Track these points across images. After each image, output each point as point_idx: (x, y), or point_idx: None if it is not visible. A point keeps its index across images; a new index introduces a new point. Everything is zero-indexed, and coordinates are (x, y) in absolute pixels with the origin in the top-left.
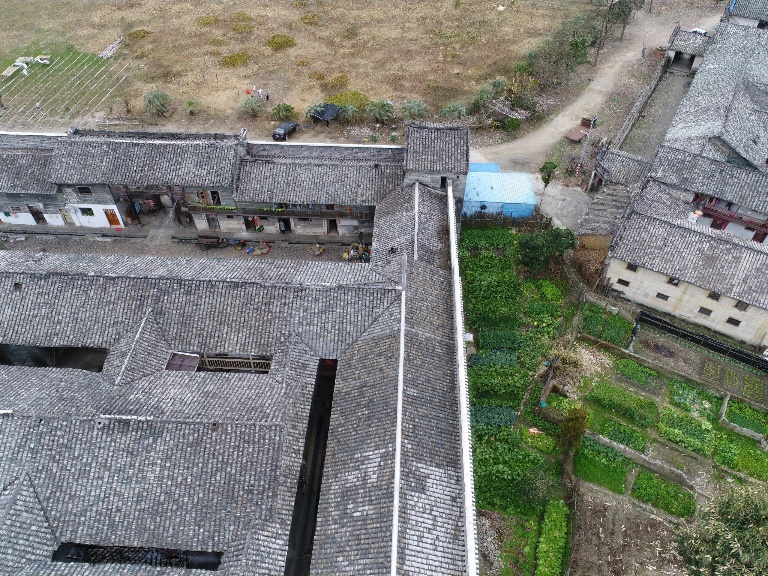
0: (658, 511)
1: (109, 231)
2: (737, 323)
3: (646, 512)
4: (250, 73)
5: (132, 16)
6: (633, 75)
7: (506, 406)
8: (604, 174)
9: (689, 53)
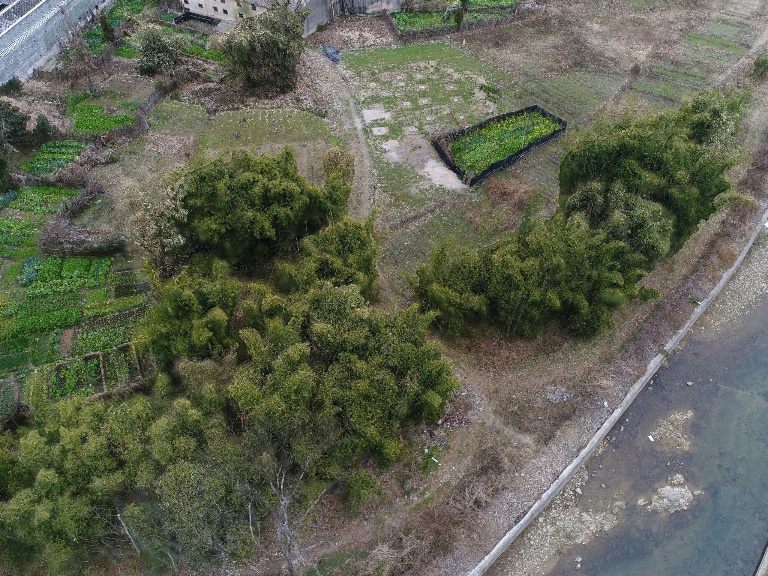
0: None
1: None
2: (227, 12)
3: None
4: None
5: None
6: None
7: (100, 38)
8: None
9: None
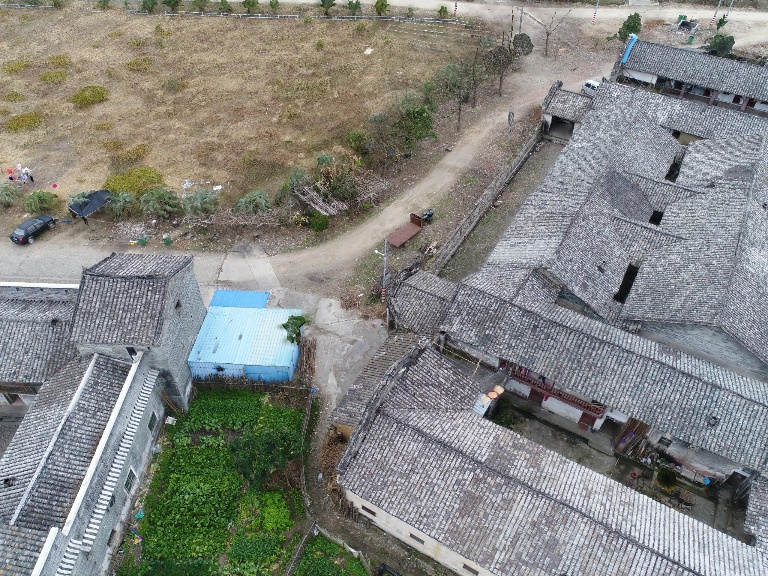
0: None
1: None
2: None
3: None
4: (32, 141)
5: None
6: (500, 145)
7: None
8: (394, 316)
9: (567, 119)
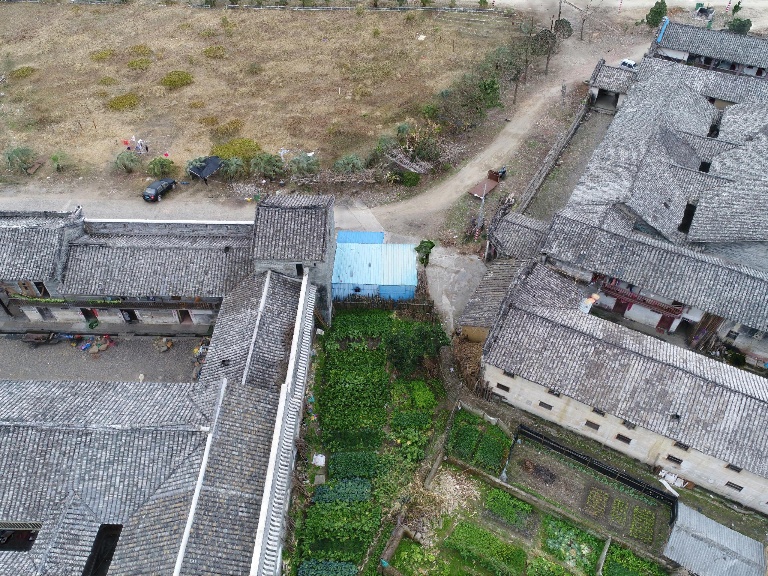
0: None
1: None
2: (627, 440)
3: None
4: (135, 118)
5: (20, 50)
6: (553, 115)
7: (346, 560)
8: (497, 246)
9: (612, 91)
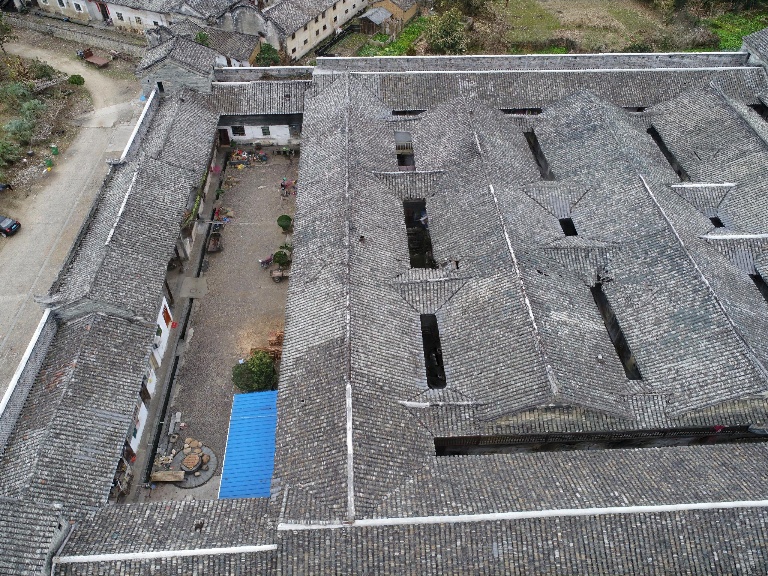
0: None
1: (175, 334)
2: None
3: None
4: None
5: None
6: (7, 32)
7: None
8: None
9: None
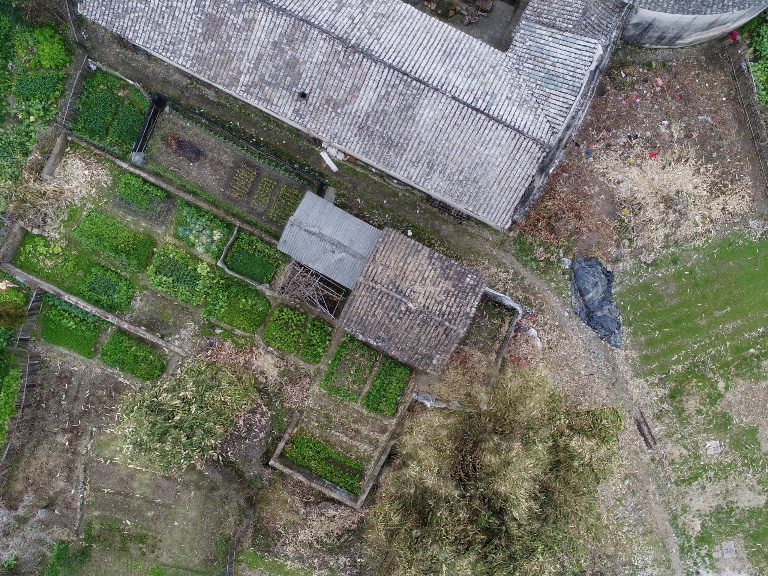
0: (125, 375)
1: None
2: None
3: (114, 375)
4: None
5: None
6: None
7: None
8: None
9: None
